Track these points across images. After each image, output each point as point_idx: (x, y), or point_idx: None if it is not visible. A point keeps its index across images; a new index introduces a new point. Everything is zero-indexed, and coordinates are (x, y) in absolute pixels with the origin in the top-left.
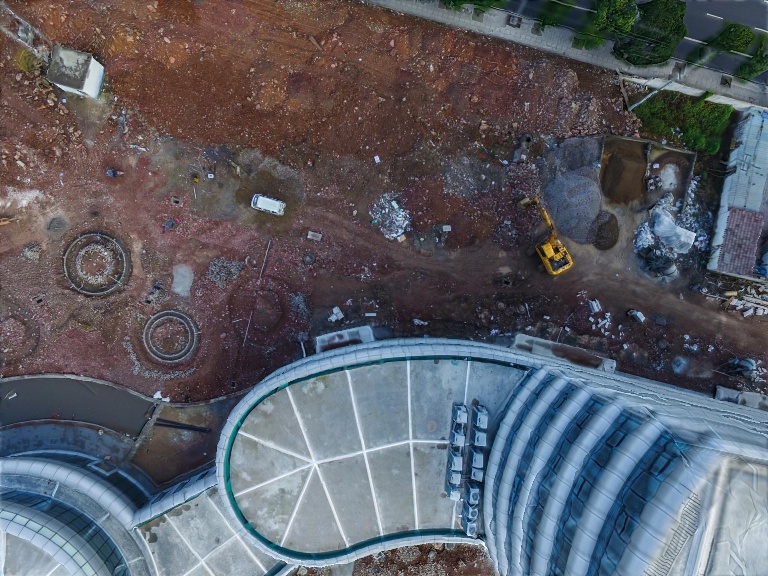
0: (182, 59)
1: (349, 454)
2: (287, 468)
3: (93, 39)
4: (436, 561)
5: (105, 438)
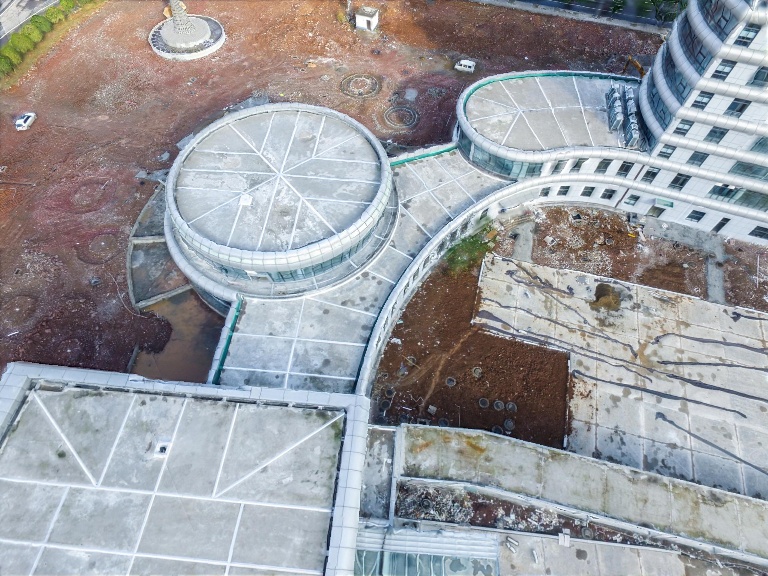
0: (420, 20)
1: (542, 108)
2: (503, 112)
3: None
4: (600, 251)
5: None
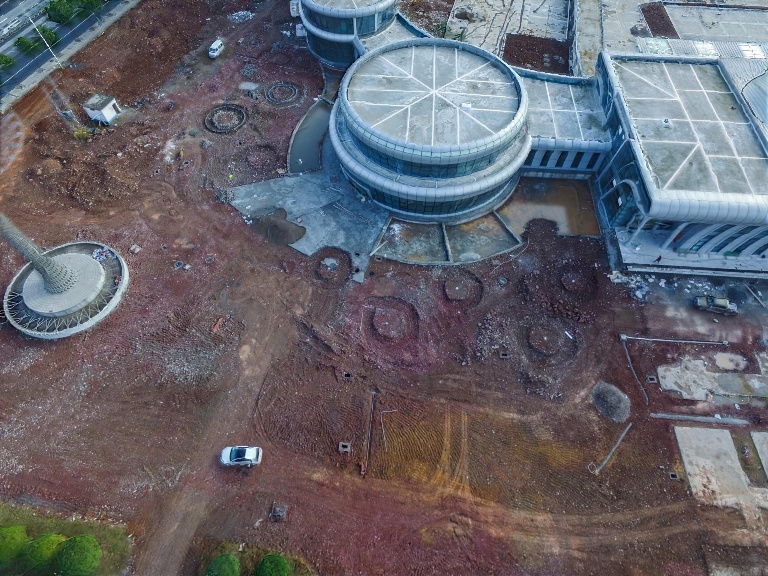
0: (117, 74)
1: None
2: None
3: (84, 111)
4: None
5: None
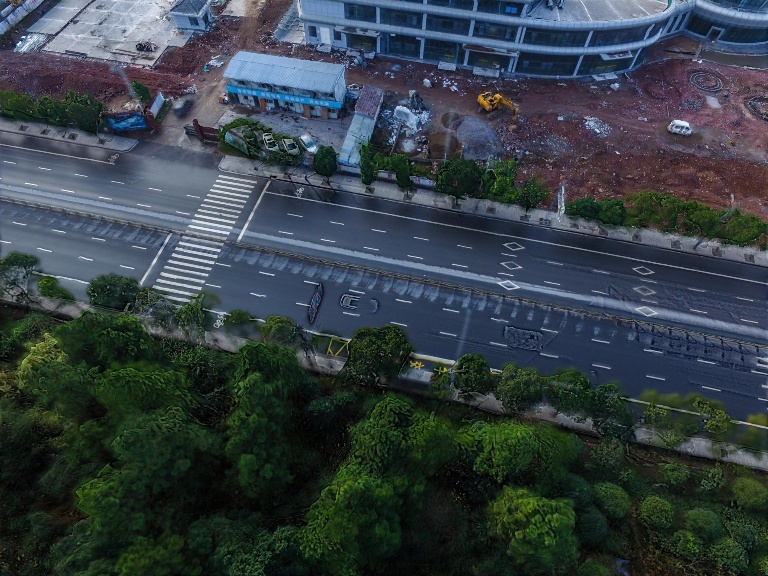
0: None
1: None
2: None
3: None
4: None
5: (719, 48)
